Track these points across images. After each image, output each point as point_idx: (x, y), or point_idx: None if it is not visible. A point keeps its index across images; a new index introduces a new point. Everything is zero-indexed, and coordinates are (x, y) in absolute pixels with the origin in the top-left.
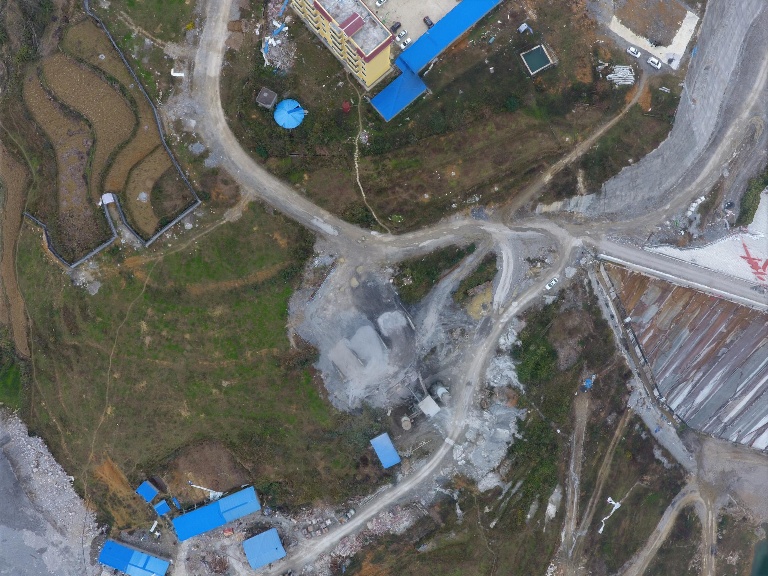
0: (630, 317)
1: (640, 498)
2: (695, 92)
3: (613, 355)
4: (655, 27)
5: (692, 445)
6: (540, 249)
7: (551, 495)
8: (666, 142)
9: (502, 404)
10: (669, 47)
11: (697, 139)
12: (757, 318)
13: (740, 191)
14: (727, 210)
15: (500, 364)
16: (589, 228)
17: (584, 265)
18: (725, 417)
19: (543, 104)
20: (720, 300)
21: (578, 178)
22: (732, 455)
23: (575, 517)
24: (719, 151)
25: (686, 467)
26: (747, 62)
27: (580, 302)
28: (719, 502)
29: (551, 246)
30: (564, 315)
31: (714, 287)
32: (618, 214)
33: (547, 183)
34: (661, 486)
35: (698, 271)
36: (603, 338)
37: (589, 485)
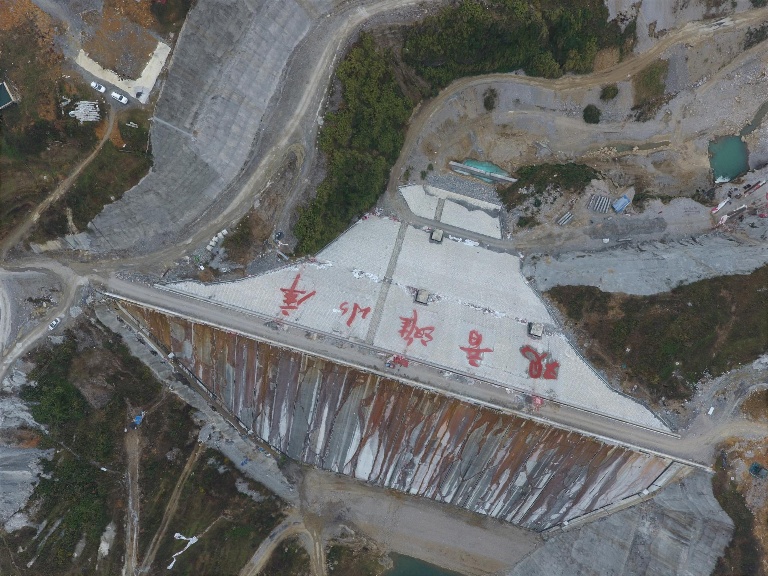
0: (173, 353)
1: (219, 532)
2: (198, 123)
3: (160, 391)
4: (124, 60)
5: (294, 476)
6: (40, 289)
7: (103, 533)
8: (149, 178)
9: (11, 446)
10: (138, 80)
11: (218, 170)
12: (281, 354)
13: (288, 221)
14: (278, 240)
15: (5, 406)
16: (97, 266)
17: (91, 304)
18: (315, 449)
19: (12, 143)
20: (238, 337)
21: (68, 216)
22: (335, 486)
23: (135, 554)
24: (252, 181)
25: (286, 499)
26: (289, 87)
27: (99, 341)
28: (325, 533)
29: (53, 285)
30: (84, 354)
31: (225, 324)
32: (130, 250)
33: (35, 222)
34: (248, 519)
35: (209, 308)
36: (135, 376)
37: (149, 522)
